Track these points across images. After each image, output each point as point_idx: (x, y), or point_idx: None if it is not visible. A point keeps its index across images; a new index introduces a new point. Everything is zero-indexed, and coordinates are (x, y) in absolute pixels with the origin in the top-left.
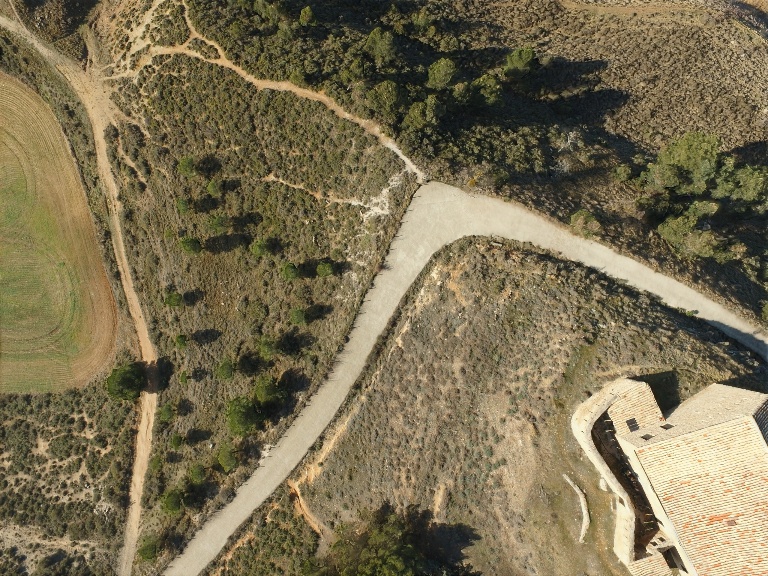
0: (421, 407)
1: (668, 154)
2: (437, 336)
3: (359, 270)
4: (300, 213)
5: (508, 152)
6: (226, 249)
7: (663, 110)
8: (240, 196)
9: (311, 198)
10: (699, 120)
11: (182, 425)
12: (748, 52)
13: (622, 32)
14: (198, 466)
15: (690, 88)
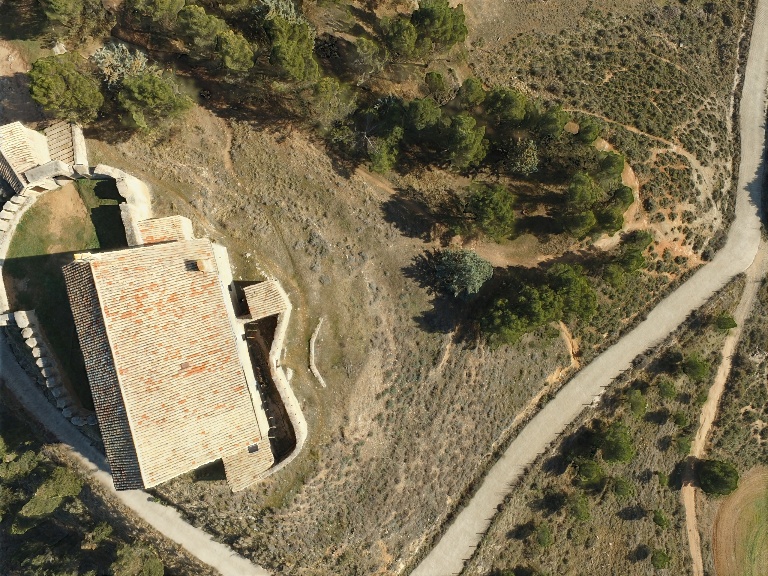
0: (443, 443)
1: None
2: (413, 511)
3: None
4: None
5: None
6: None
7: None
8: None
9: None
10: None
11: (670, 429)
12: None
13: None
14: None
15: None
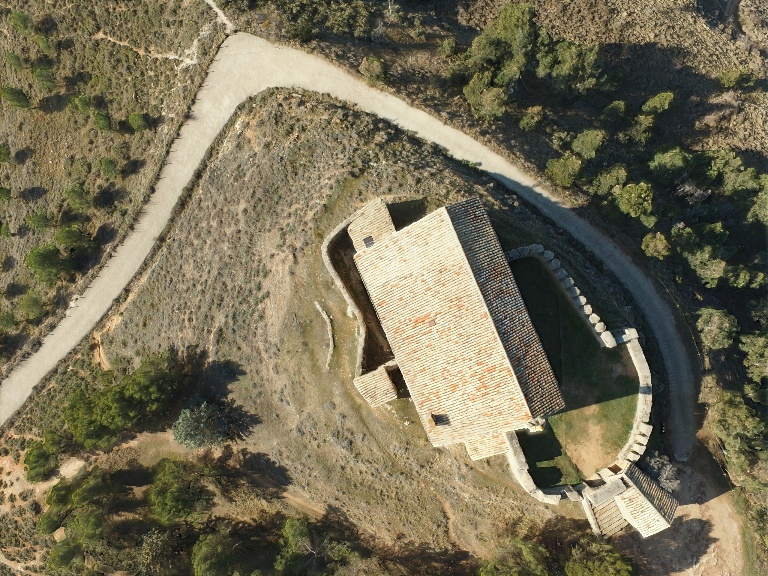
0: (208, 250)
1: (494, 30)
2: (229, 181)
3: (168, 121)
4: (123, 69)
5: (331, 17)
6: (58, 109)
7: None
8: (73, 55)
9: (134, 54)
10: (556, 19)
11: (3, 280)
12: None
13: None
14: (7, 314)
15: None
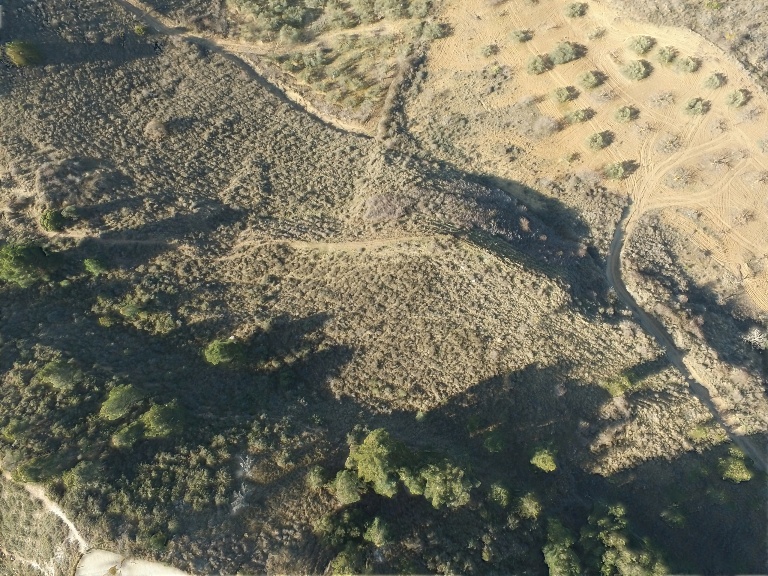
0: None
1: None
2: None
3: None
4: None
5: (189, 482)
6: None
7: (392, 358)
8: None
9: None
10: (431, 362)
11: None
12: (479, 276)
13: (351, 271)
14: None
15: (419, 328)
